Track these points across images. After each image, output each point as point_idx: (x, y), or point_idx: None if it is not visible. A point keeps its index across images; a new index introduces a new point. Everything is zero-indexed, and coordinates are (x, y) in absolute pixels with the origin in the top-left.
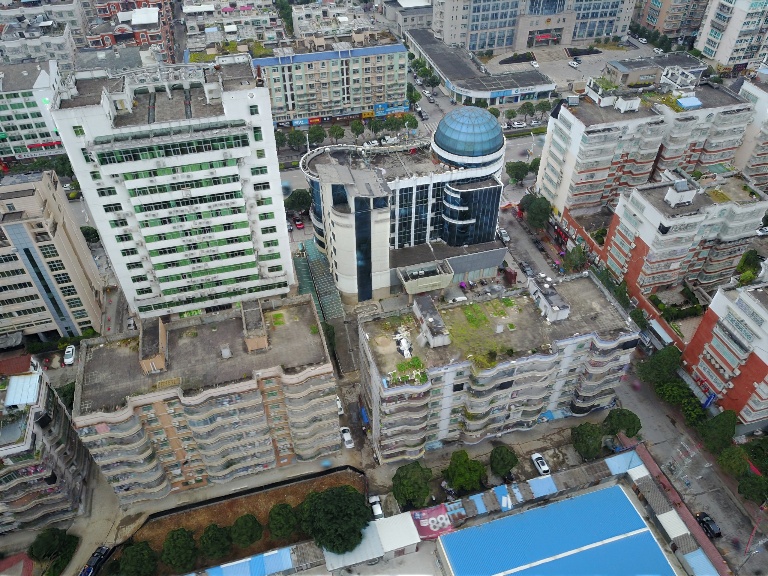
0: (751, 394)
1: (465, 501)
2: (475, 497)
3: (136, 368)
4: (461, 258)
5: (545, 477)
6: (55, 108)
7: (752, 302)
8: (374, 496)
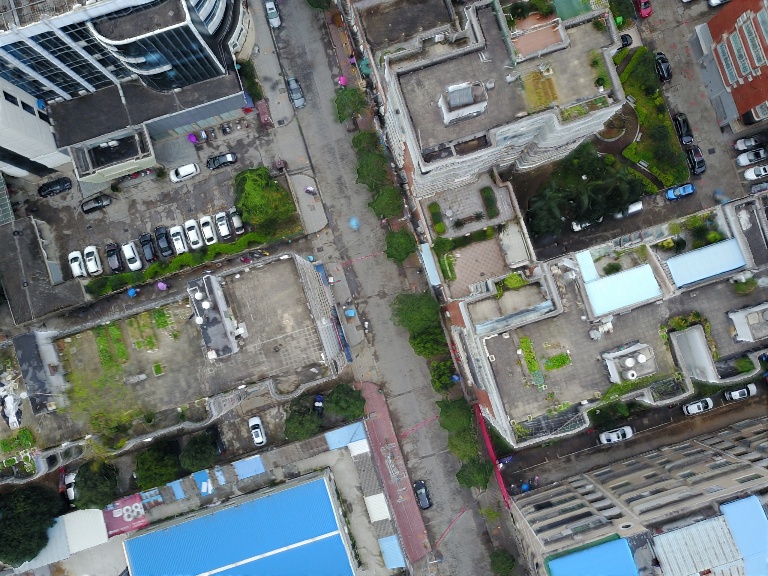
0: None
1: (162, 488)
2: (173, 484)
3: None
4: (169, 118)
5: (253, 458)
6: None
7: None
8: (71, 475)
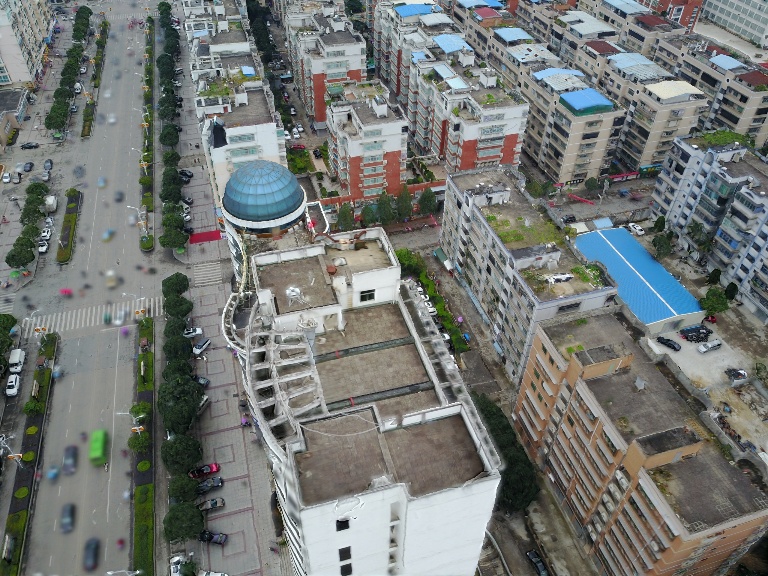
0: (513, 157)
1: None
2: None
3: (692, 466)
4: None
5: None
6: (481, 477)
7: (493, 111)
8: None
